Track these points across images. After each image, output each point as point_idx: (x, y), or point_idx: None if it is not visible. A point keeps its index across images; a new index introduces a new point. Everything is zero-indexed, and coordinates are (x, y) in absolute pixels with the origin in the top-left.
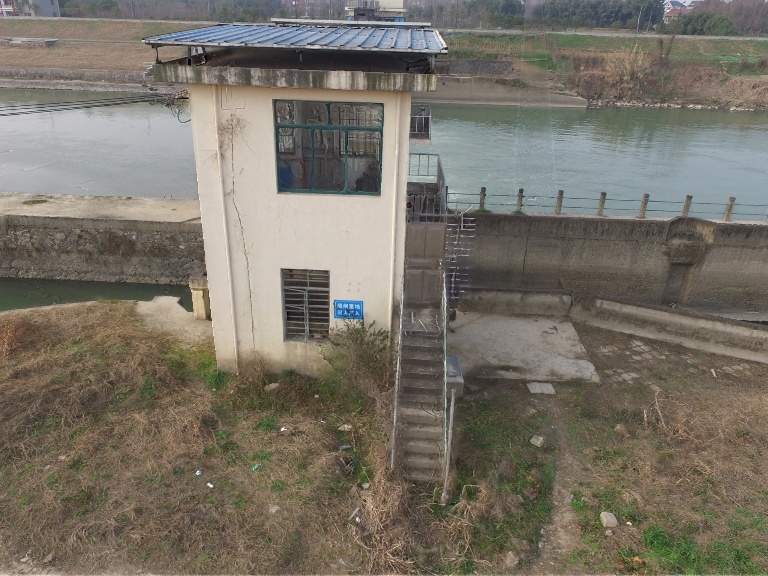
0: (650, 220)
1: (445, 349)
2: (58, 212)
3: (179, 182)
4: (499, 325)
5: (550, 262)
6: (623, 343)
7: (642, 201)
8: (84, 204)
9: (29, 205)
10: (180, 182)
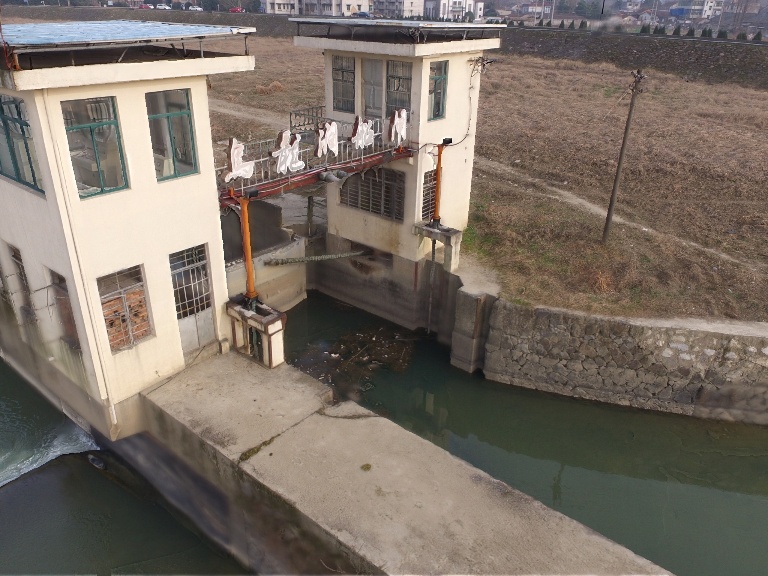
0: None
1: None
2: (618, 569)
3: None
4: None
5: None
6: None
7: None
8: None
9: None
10: None
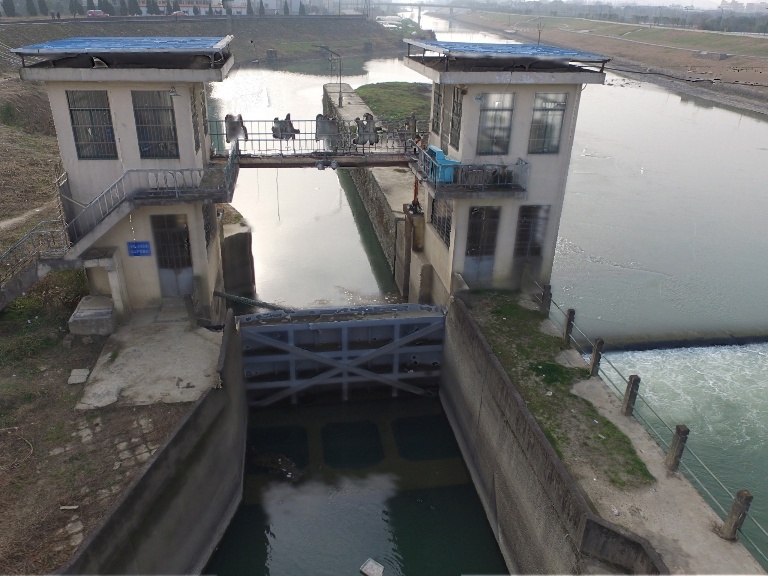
0: (575, 485)
1: (4, 256)
2: (385, 179)
3: (632, 220)
4: (199, 353)
5: (492, 438)
6: (157, 437)
7: (733, 500)
8: (408, 181)
9: (393, 171)
10: (633, 220)
